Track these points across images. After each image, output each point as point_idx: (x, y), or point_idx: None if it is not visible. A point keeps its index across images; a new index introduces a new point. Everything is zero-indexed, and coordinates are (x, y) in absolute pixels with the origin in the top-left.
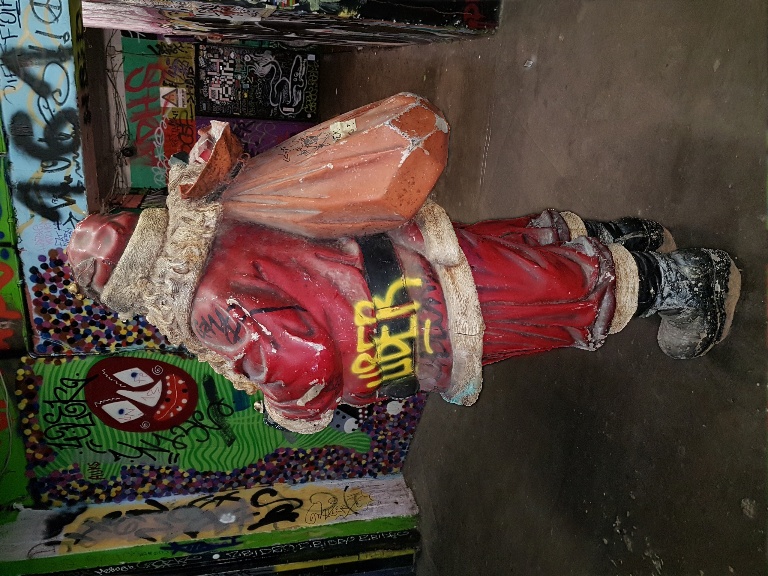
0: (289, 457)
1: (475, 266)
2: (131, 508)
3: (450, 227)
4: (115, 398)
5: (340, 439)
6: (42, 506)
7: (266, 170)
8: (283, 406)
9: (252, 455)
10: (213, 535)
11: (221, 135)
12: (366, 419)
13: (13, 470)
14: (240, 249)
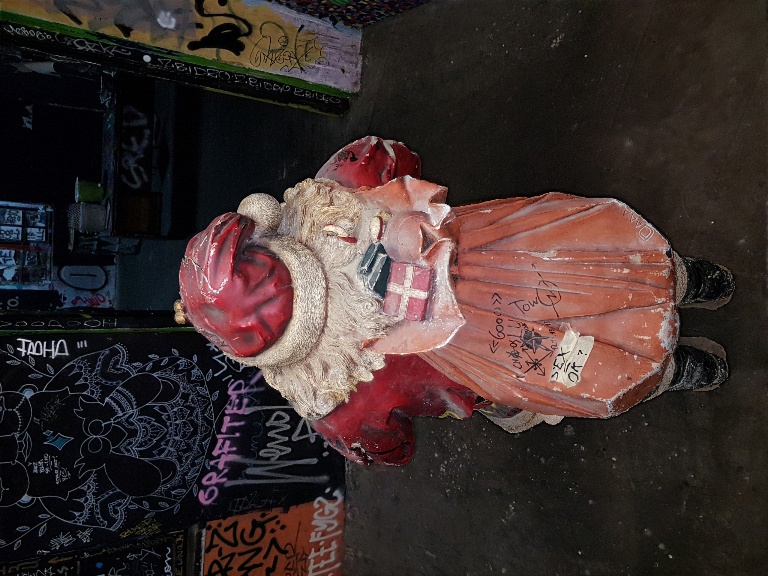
0: None
1: None
2: None
3: None
4: None
5: None
6: None
7: (464, 344)
8: None
9: None
10: (149, 41)
11: None
12: None
13: None
14: (386, 385)
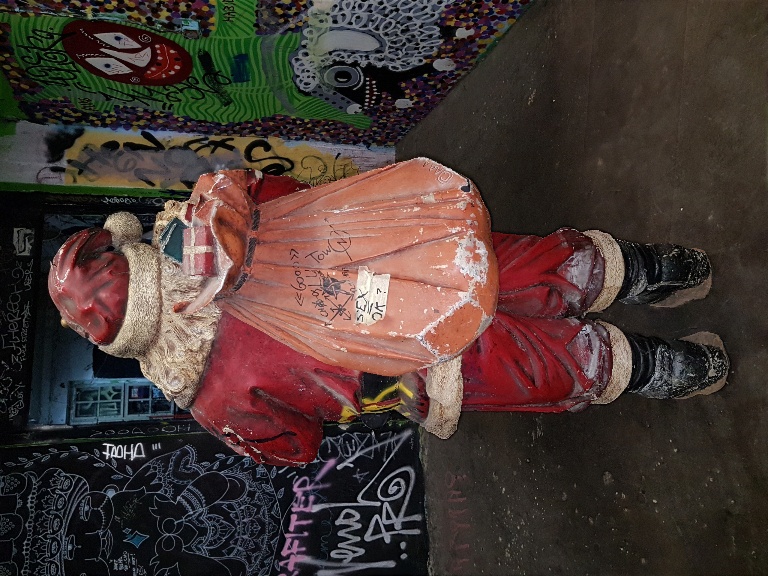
0: (286, 121)
1: (471, 379)
2: (128, 140)
3: (456, 377)
4: (99, 54)
5: (341, 116)
6: (38, 121)
7: (274, 301)
8: None
9: (249, 115)
10: None
11: (222, 286)
12: (371, 107)
13: (1, 98)
14: (238, 363)
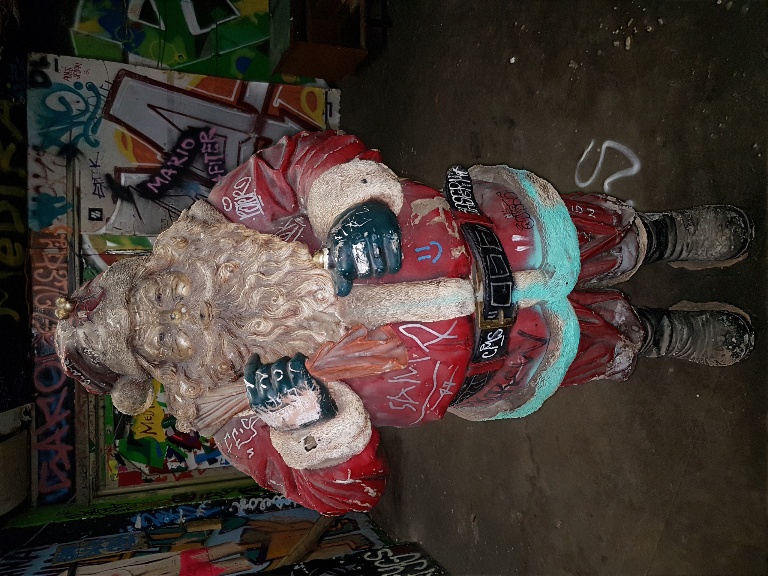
0: None
1: None
2: None
3: None
4: None
5: None
6: None
7: None
8: (319, 147)
9: None
10: None
11: None
12: None
13: None
14: None
